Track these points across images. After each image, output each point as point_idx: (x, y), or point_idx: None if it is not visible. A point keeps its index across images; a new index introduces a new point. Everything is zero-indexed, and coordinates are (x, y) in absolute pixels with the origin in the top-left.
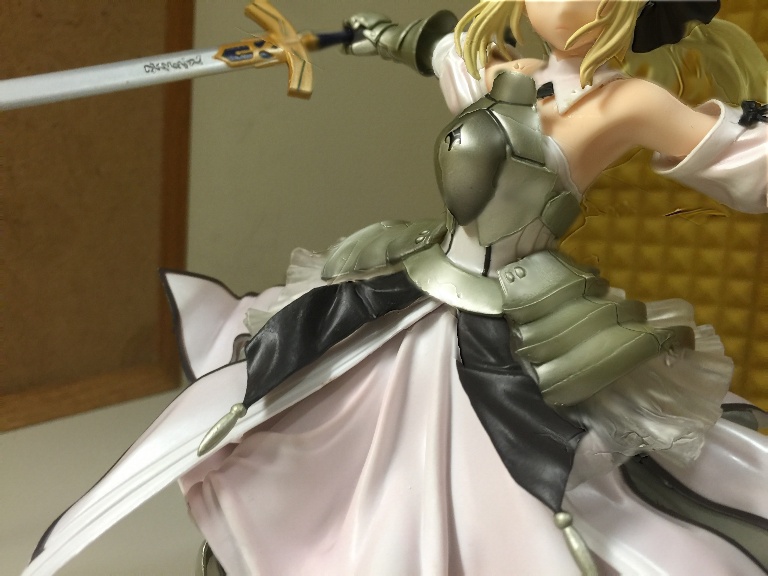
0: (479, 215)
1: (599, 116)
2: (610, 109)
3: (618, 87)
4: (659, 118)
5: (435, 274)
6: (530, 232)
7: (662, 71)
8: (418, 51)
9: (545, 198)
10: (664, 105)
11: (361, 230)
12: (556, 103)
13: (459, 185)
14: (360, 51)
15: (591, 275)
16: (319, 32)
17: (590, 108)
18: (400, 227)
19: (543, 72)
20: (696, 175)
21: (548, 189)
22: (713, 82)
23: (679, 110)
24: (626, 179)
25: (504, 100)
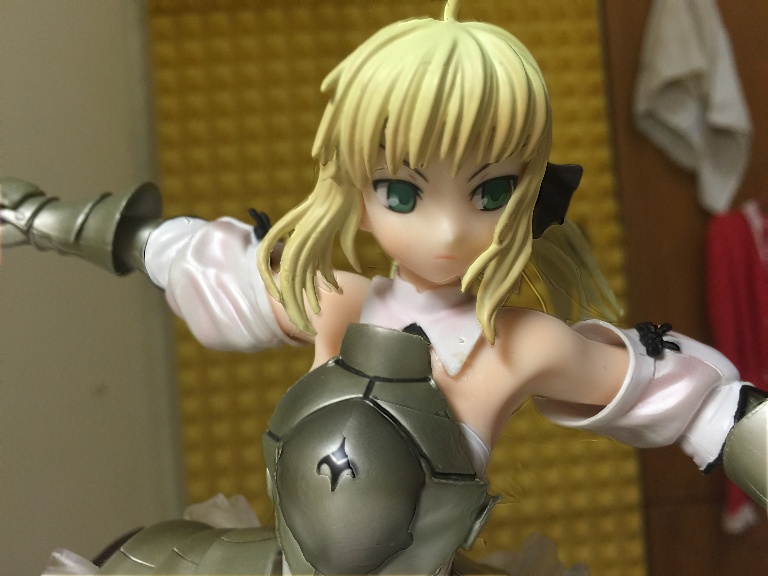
0: (375, 569)
1: (506, 374)
2: (518, 362)
3: (513, 326)
4: (575, 365)
5: None
6: None
7: None
8: (116, 246)
9: (470, 517)
10: (574, 346)
11: None
12: (440, 359)
13: (354, 543)
14: None
15: None
16: None
17: (487, 361)
18: (168, 561)
19: (388, 303)
20: (611, 424)
21: (476, 504)
22: (553, 283)
23: (587, 348)
24: (511, 432)
25: (383, 375)
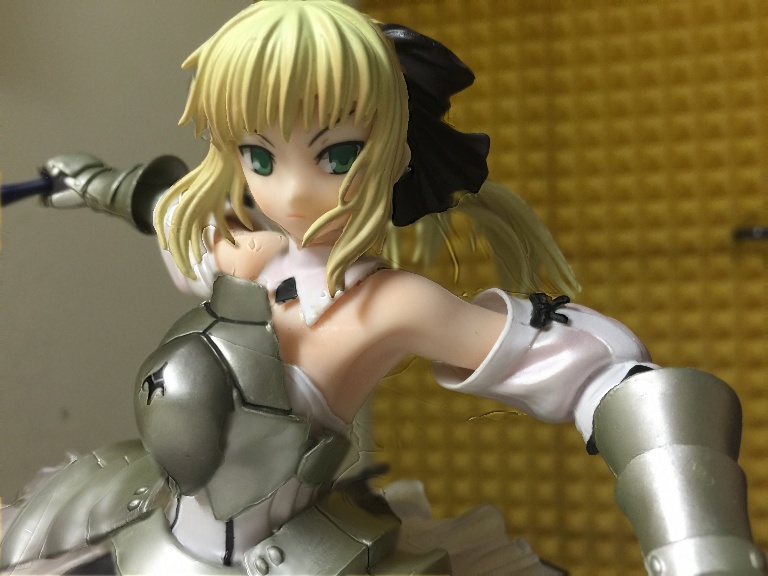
0: (208, 482)
1: (359, 328)
2: (372, 318)
3: (379, 285)
4: (435, 326)
5: (155, 567)
6: (285, 492)
7: (431, 248)
8: (135, 208)
9: (298, 451)
10: (439, 308)
11: (61, 471)
12: (301, 310)
13: (169, 452)
14: (63, 203)
15: (374, 537)
16: (0, 183)
17: (346, 316)
18: (116, 465)
19: (283, 260)
20: (489, 390)
21: (301, 440)
22: (491, 254)
23: (458, 312)
24: (405, 390)
25: (227, 317)
